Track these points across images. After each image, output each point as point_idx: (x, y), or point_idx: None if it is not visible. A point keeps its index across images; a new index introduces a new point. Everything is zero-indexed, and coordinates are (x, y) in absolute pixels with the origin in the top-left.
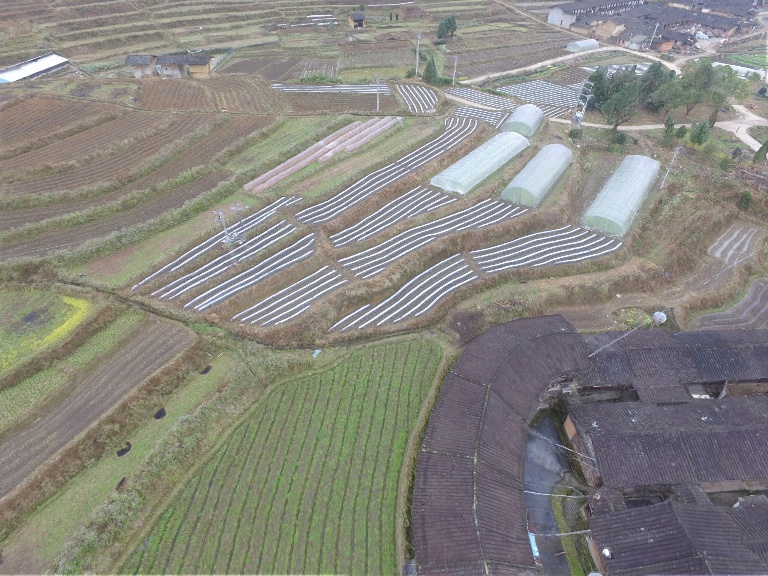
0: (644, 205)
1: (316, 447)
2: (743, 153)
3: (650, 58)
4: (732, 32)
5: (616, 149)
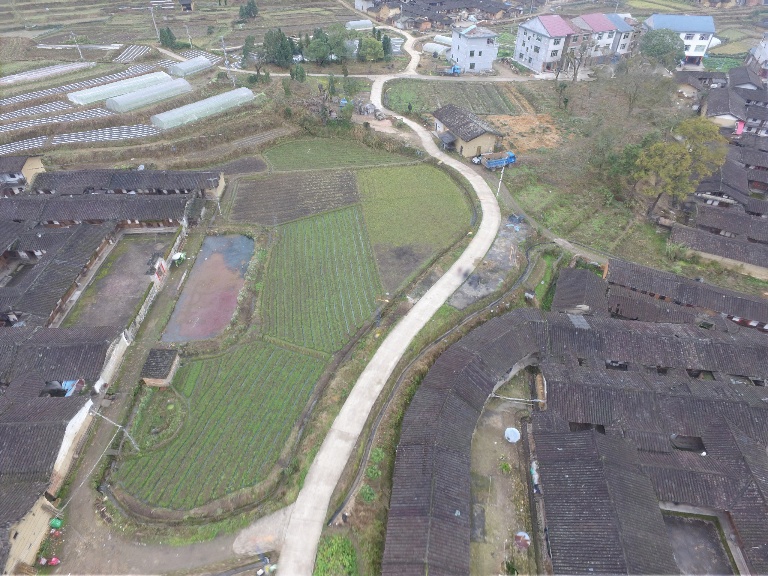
0: (212, 115)
1: None
2: (363, 94)
3: (403, 34)
4: (500, 16)
5: (244, 86)
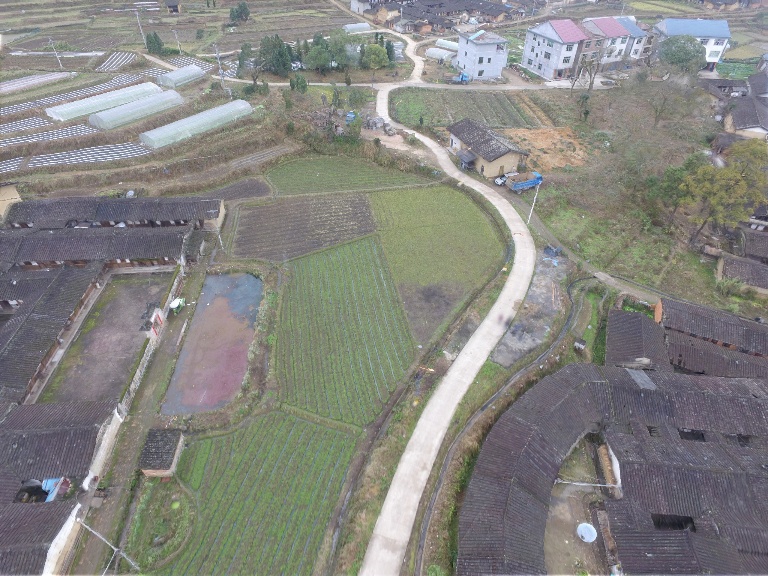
0: (207, 131)
1: None
2: (368, 104)
3: (403, 38)
4: (502, 18)
5: (241, 97)
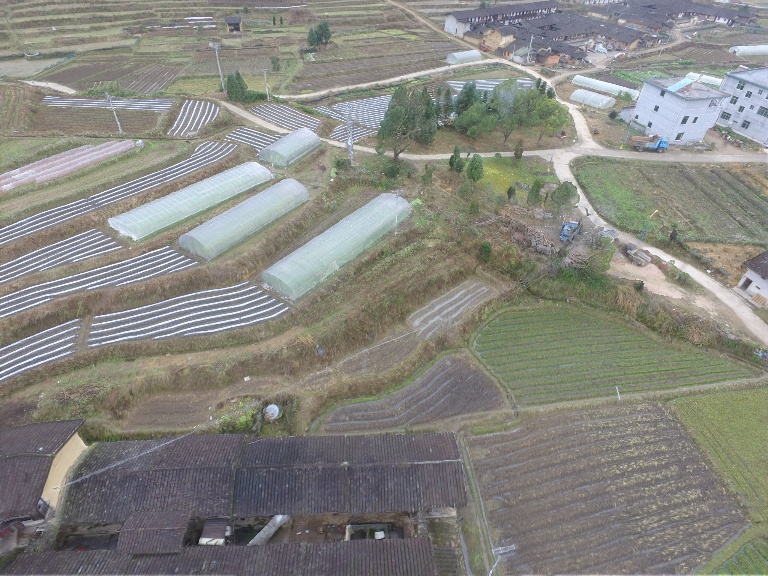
0: (359, 257)
1: None
2: (549, 188)
3: (528, 73)
4: (635, 46)
5: (383, 183)
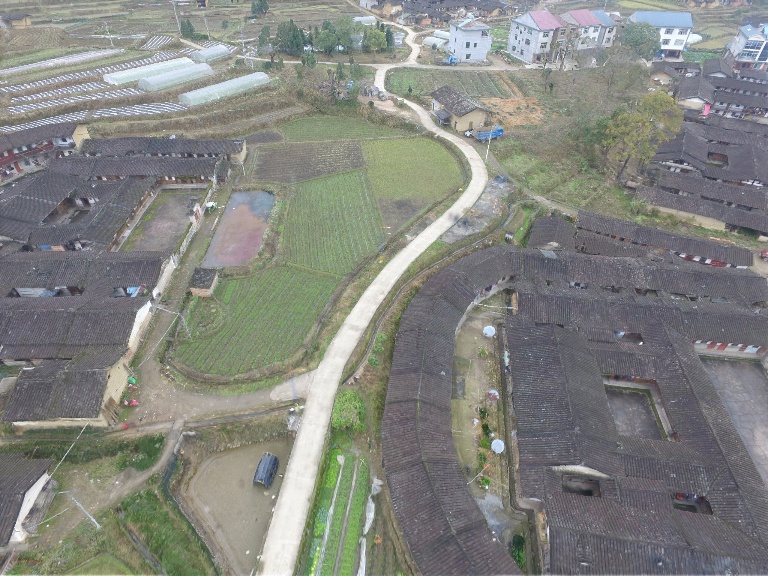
0: (232, 95)
1: None
2: (367, 80)
3: (404, 29)
4: (497, 13)
5: None
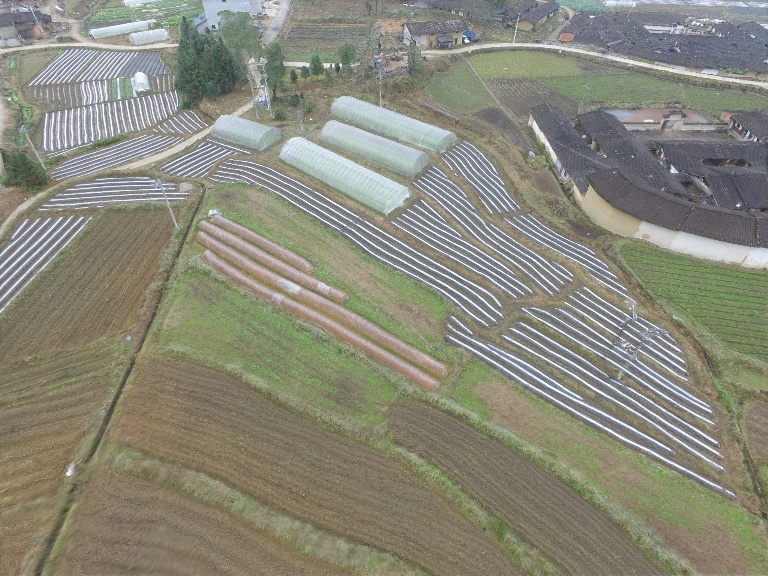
0: None
1: (765, 317)
2: None
3: (55, 46)
4: None
5: None
